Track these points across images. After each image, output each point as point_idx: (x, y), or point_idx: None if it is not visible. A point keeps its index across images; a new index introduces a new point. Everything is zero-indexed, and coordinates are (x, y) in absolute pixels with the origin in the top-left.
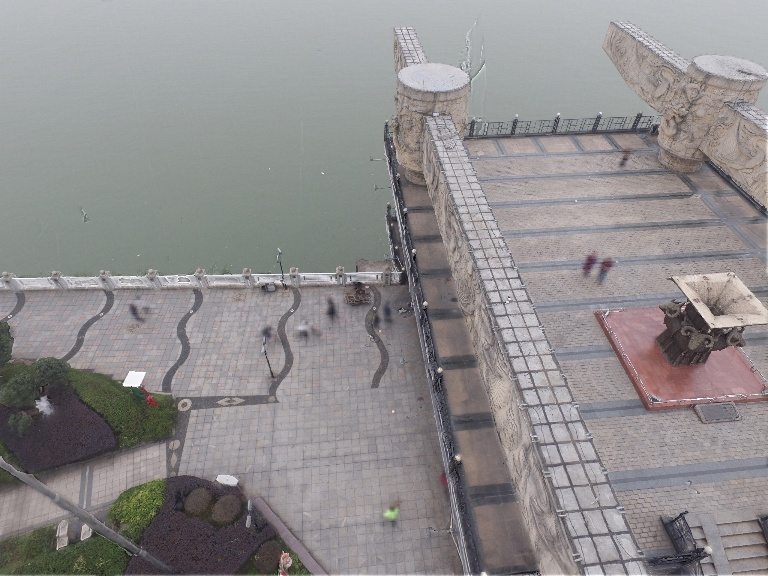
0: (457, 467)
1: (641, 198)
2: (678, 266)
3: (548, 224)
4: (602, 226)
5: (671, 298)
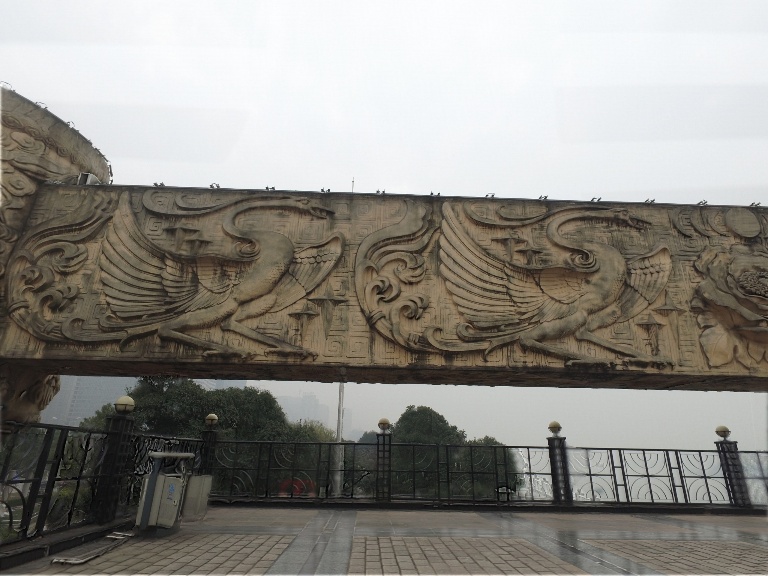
0: (374, 439)
1: None
2: None
3: None
4: None
5: None
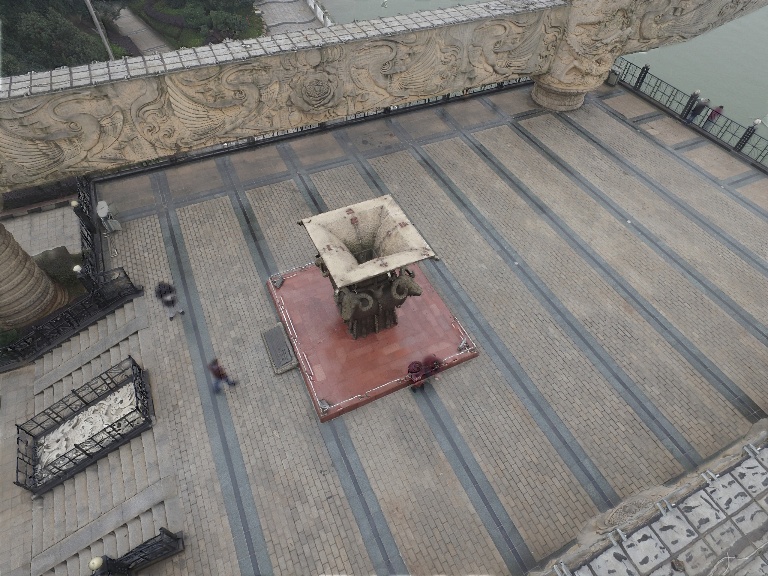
0: None
1: (718, 297)
2: (558, 334)
3: (547, 197)
4: (589, 248)
5: (474, 319)
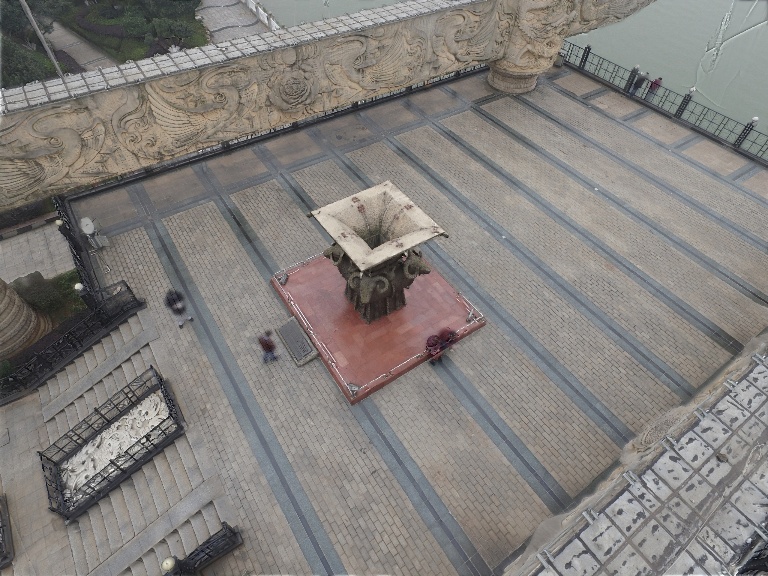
0: None
1: (683, 248)
2: (553, 296)
3: (520, 174)
4: (566, 217)
5: (475, 292)
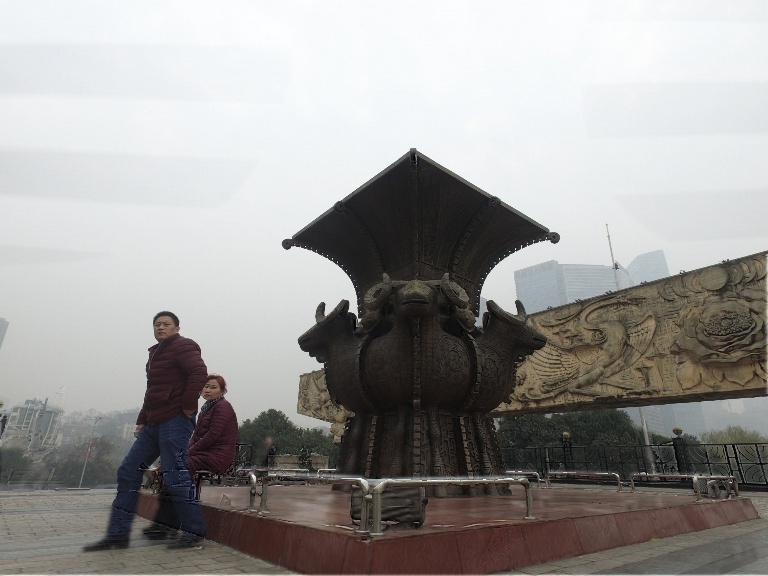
0: None
1: None
2: None
3: None
4: None
5: None
